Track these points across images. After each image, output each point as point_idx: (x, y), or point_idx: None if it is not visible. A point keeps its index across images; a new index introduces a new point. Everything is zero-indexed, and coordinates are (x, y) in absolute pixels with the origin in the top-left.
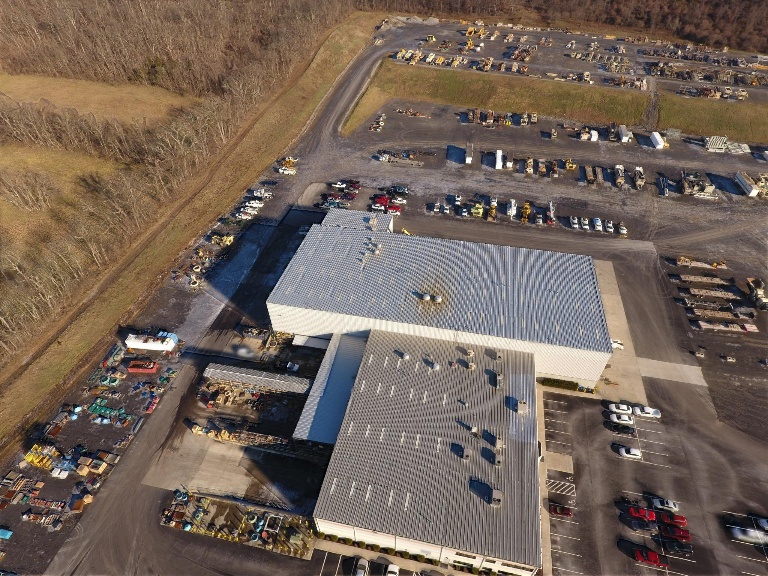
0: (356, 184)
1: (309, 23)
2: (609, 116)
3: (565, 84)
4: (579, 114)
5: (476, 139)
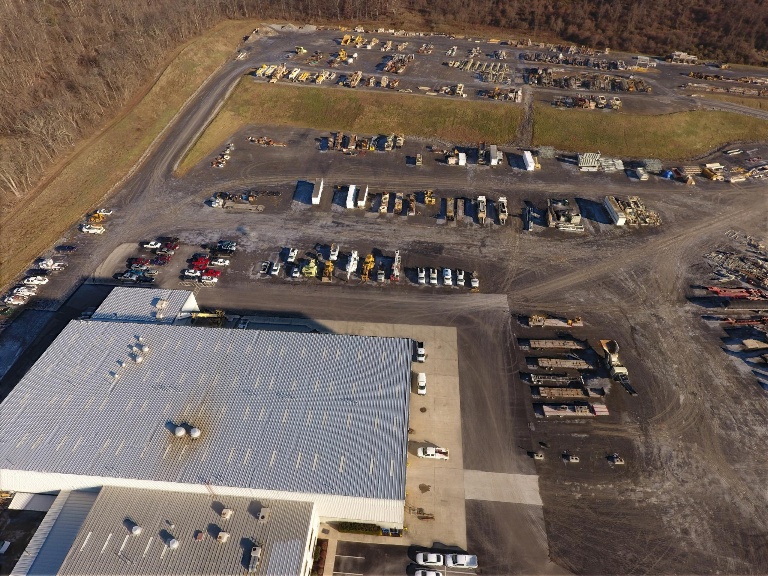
0: (174, 242)
1: (153, 39)
2: (482, 134)
3: (436, 99)
4: (451, 133)
5: (332, 171)
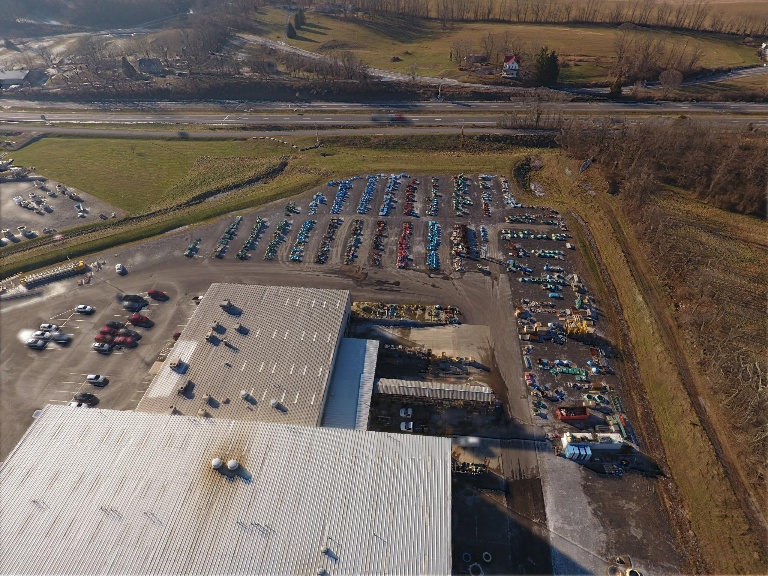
0: None
1: None
2: None
3: None
4: None
5: None
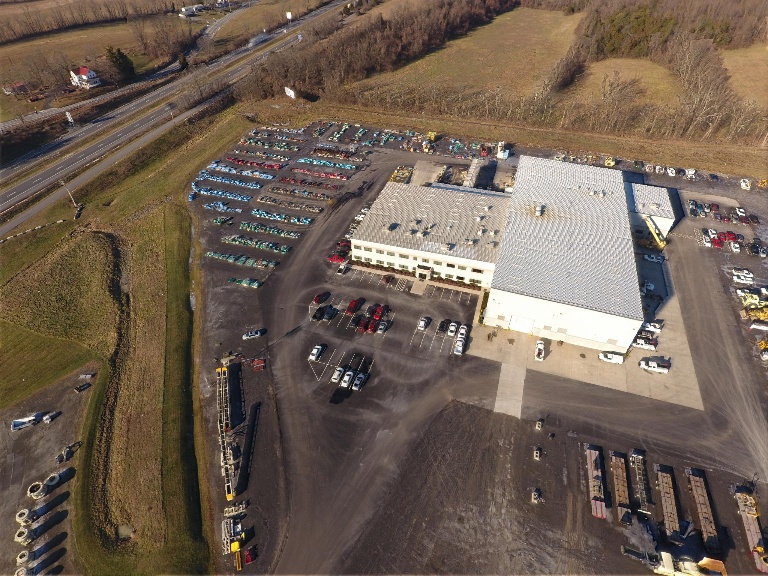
0: (751, 221)
1: None
2: None
3: None
4: None
5: None
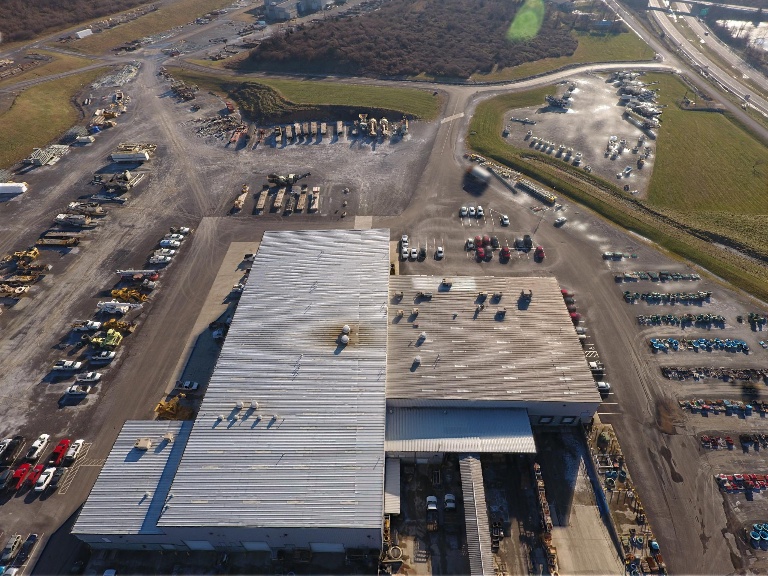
0: None
1: None
2: None
3: None
4: None
5: None
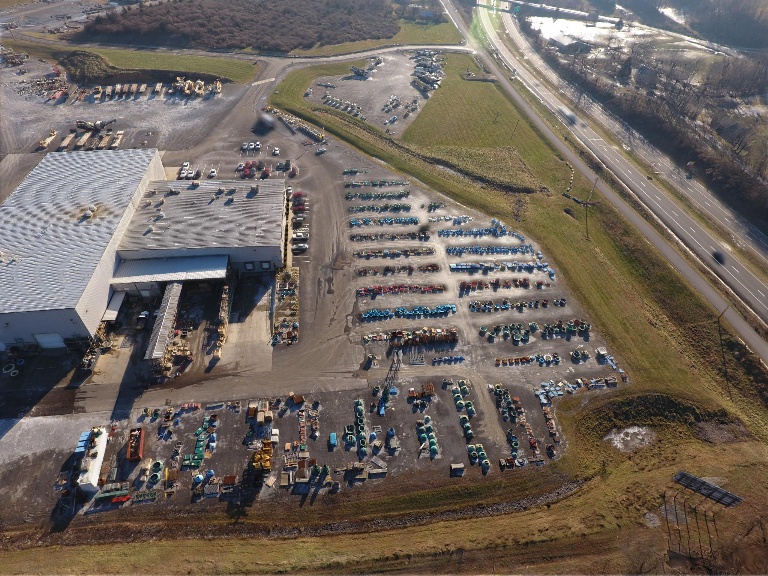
0: None
1: None
2: None
3: None
4: None
5: None
